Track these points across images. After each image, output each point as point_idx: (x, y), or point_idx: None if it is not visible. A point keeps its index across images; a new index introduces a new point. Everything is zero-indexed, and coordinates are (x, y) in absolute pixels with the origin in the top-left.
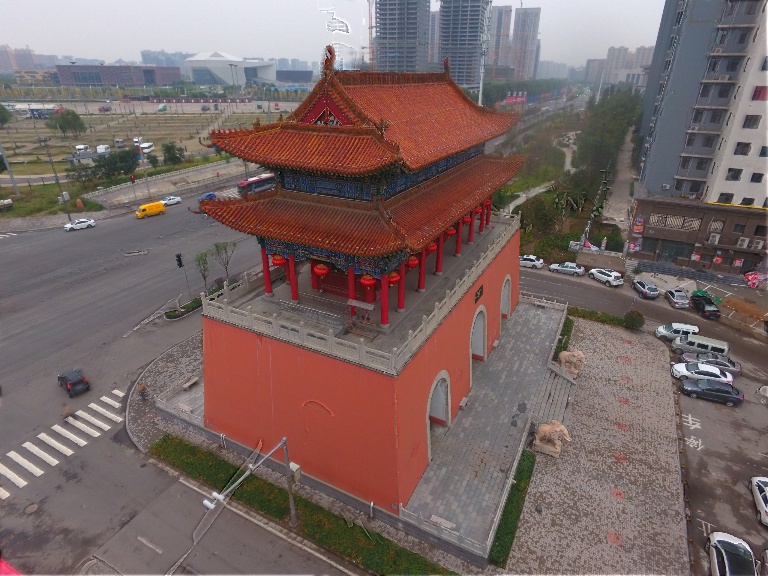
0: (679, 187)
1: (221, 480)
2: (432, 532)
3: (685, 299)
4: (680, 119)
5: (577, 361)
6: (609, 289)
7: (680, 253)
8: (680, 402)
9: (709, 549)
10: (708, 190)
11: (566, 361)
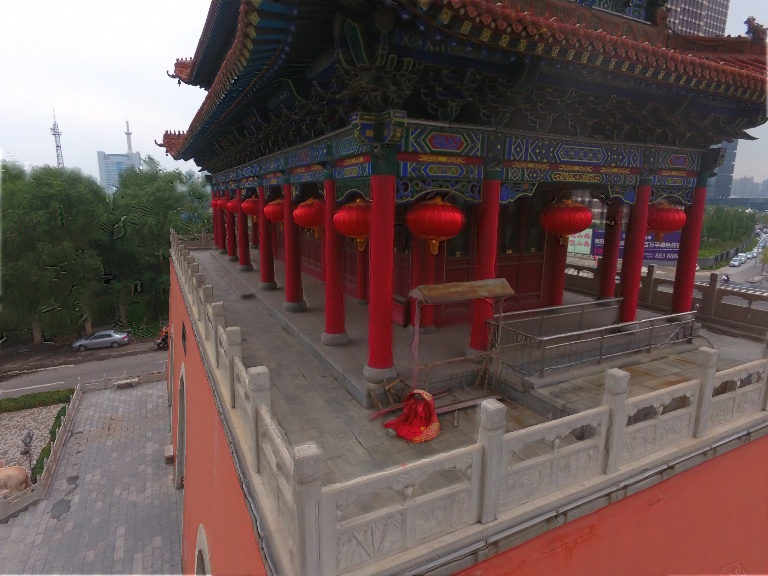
0: None
1: None
2: None
3: None
4: None
5: None
6: None
7: None
8: None
9: None
10: None
11: None
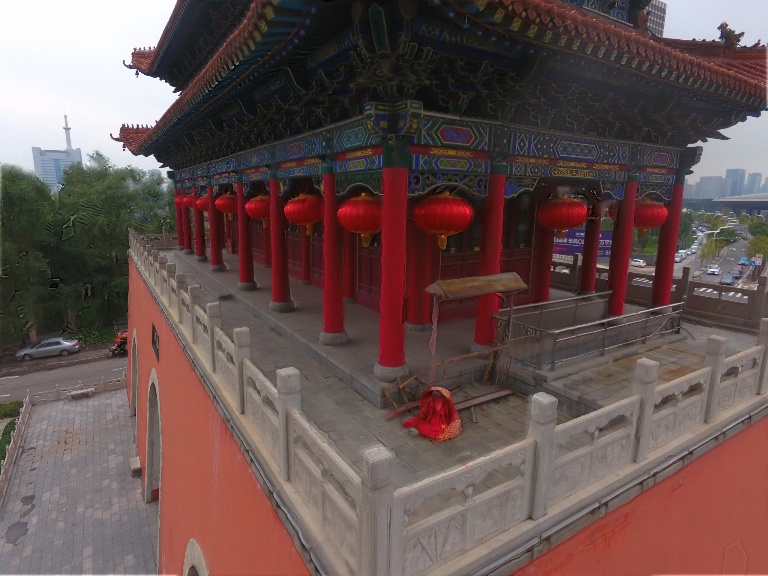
0: None
1: None
2: None
3: None
4: None
5: None
6: None
7: None
8: None
9: None
10: None
11: None
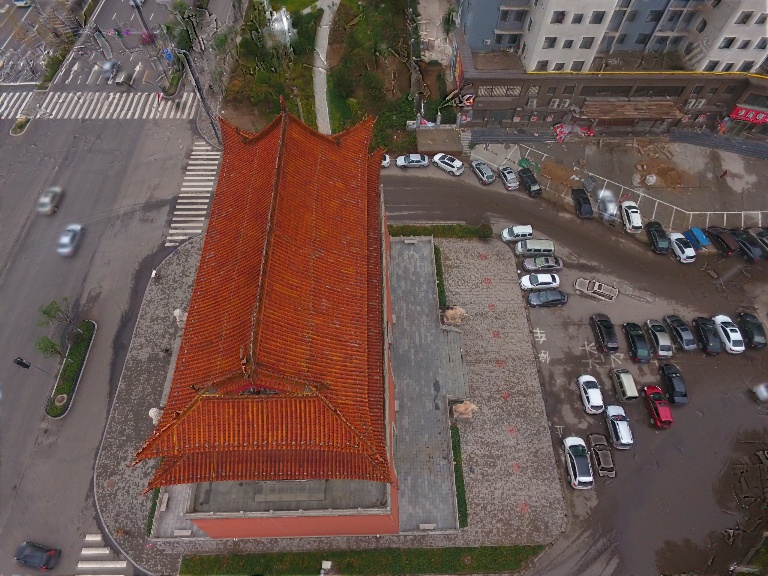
0: (498, 40)
1: (261, 573)
2: (423, 534)
3: (516, 181)
4: None
5: (455, 301)
6: (454, 180)
7: (504, 116)
8: (530, 317)
9: (565, 451)
10: (526, 52)
11: (452, 317)
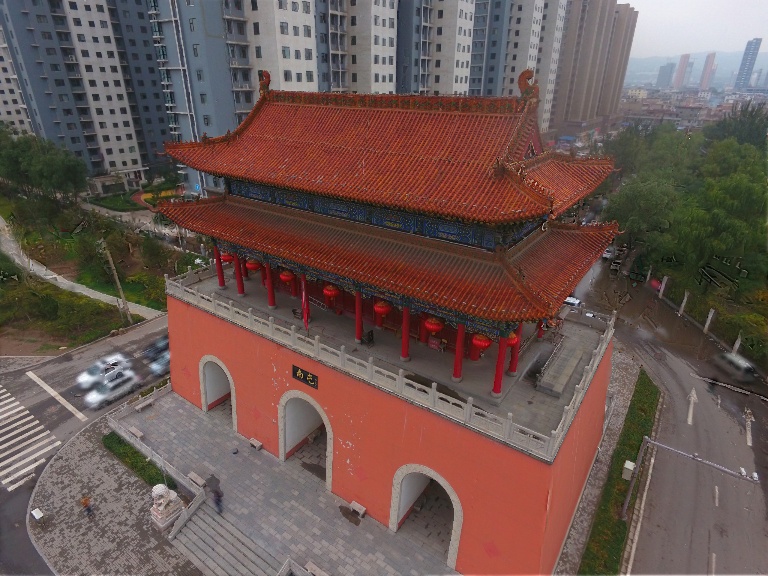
0: None
1: None
2: None
3: None
4: (229, 124)
5: None
6: None
7: None
8: None
9: None
10: None
11: None
